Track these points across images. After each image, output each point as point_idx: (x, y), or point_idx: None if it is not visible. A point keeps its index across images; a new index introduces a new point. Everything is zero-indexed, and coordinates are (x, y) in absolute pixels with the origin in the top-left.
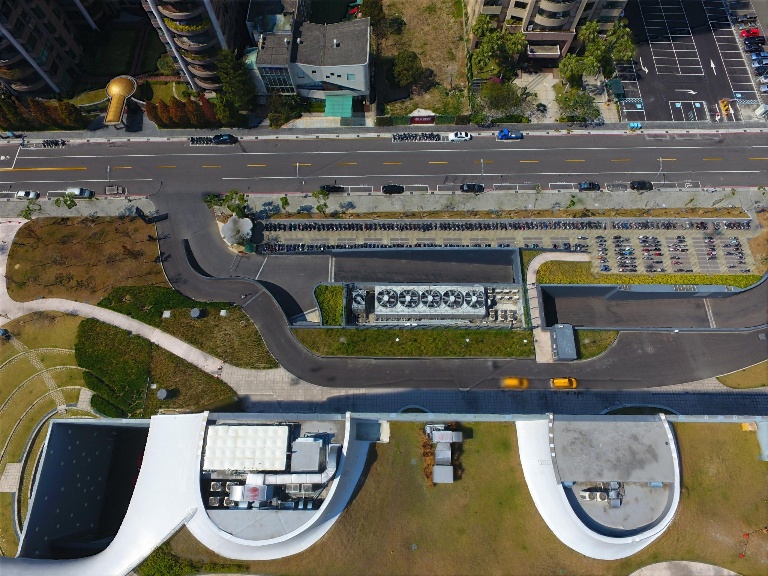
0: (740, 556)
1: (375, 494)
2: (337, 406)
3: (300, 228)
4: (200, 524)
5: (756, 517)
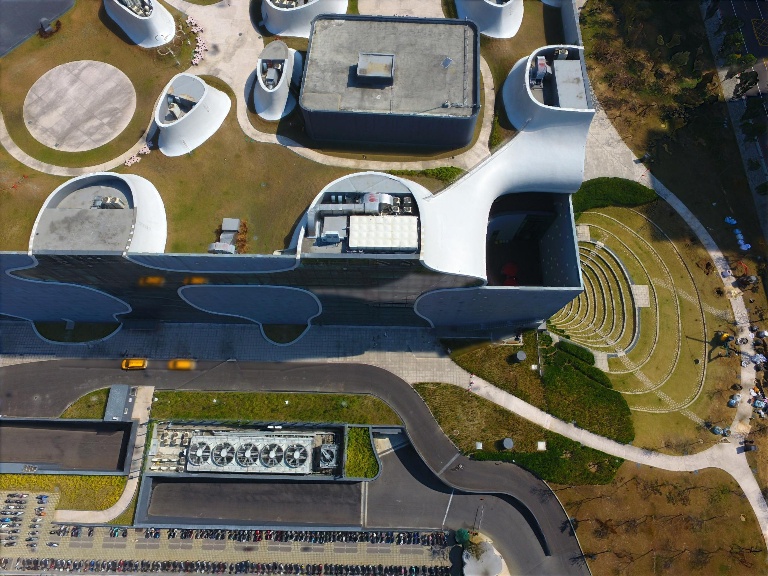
0: (27, 177)
1: (288, 215)
2: (354, 346)
3: (404, 570)
4: (420, 192)
5: (0, 198)
